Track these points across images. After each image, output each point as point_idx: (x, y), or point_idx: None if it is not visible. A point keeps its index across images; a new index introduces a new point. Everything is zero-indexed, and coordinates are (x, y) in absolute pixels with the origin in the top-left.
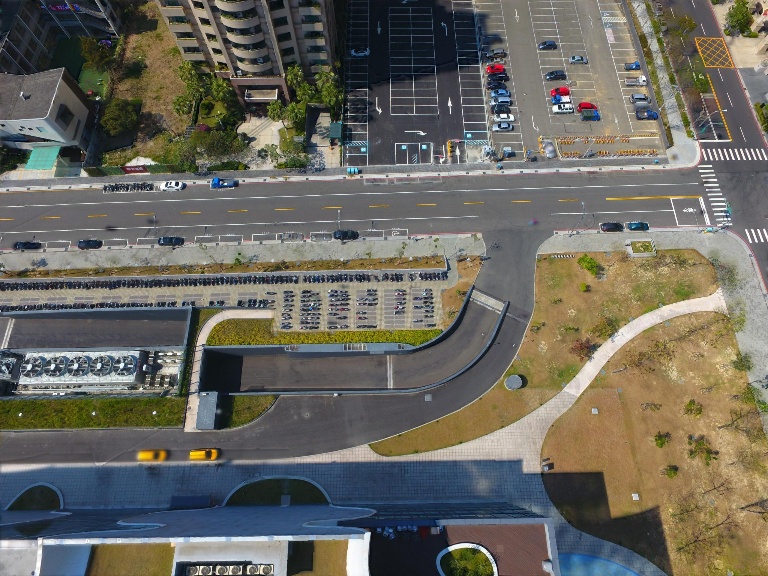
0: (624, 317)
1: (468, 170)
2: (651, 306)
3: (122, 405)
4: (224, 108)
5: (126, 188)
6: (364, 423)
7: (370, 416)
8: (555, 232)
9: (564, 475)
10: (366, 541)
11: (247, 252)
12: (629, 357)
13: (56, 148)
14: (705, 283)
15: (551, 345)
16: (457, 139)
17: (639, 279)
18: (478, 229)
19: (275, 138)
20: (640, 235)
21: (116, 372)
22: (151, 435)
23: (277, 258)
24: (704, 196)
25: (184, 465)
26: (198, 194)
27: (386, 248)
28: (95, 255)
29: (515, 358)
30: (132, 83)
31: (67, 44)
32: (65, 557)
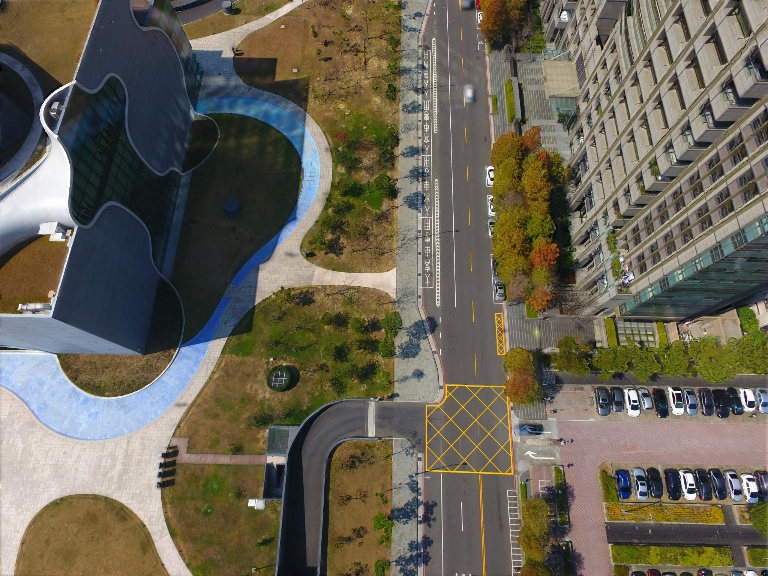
0: None
1: None
2: None
3: None
4: None
5: None
6: None
7: None
8: None
9: (249, 59)
10: None
11: None
12: (320, 1)
13: None
14: None
15: None
16: None
17: None
18: None
19: None
20: None
21: None
22: None
23: None
24: None
25: None
26: None
27: None
28: None
29: (237, 0)
30: None
31: None
32: None
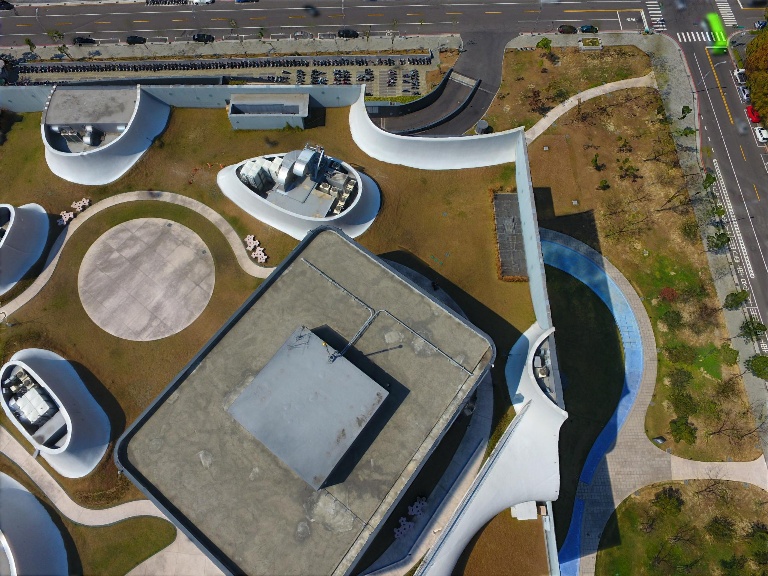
0: (574, 90)
1: None
2: (596, 83)
3: None
4: None
5: (165, 2)
6: None
7: None
8: (521, 34)
9: None
10: (363, 88)
11: (266, 46)
12: (576, 115)
13: None
14: (641, 68)
15: (513, 107)
16: None
17: (587, 65)
18: (457, 31)
19: None
20: (590, 36)
21: None
22: None
23: (291, 50)
24: (645, 10)
25: None
26: (225, 7)
27: (381, 43)
28: (141, 48)
29: (484, 116)
30: None
31: None
32: (153, 107)
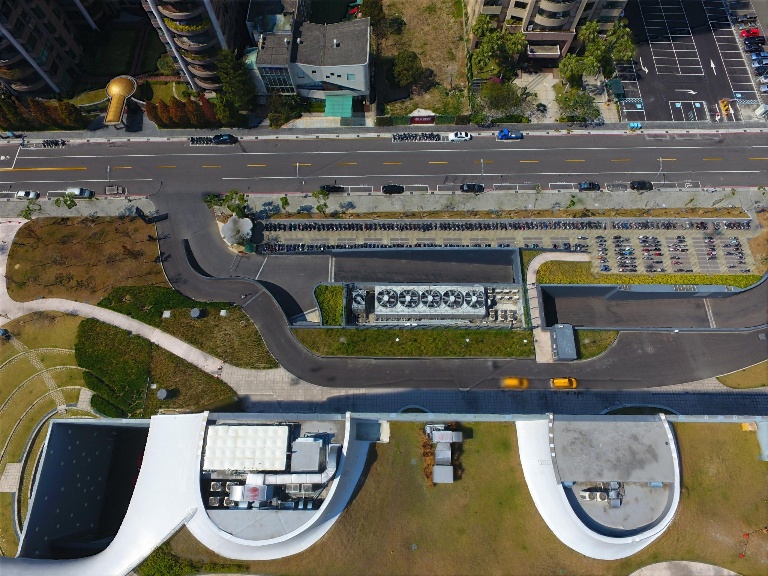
0: None
1: (745, 128)
2: None
3: (472, 336)
4: (496, 64)
5: (415, 137)
6: (707, 358)
7: (711, 352)
8: None
9: None
10: None
11: (548, 200)
12: None
13: (348, 97)
14: None
15: None
16: (728, 98)
17: None
18: None
19: (550, 94)
20: None
21: (469, 305)
22: (506, 365)
23: (579, 206)
24: None
25: (545, 392)
26: (486, 145)
27: (683, 199)
28: (400, 199)
29: None
30: (395, 39)
31: (320, 1)
32: None
